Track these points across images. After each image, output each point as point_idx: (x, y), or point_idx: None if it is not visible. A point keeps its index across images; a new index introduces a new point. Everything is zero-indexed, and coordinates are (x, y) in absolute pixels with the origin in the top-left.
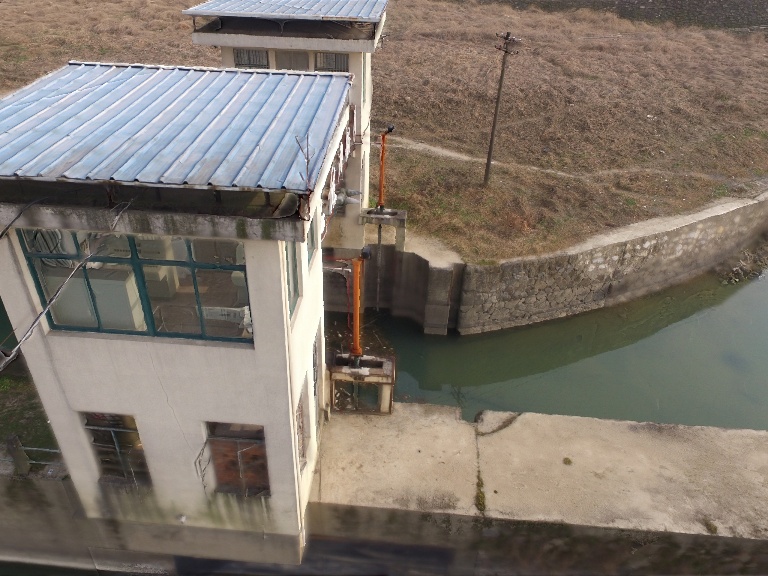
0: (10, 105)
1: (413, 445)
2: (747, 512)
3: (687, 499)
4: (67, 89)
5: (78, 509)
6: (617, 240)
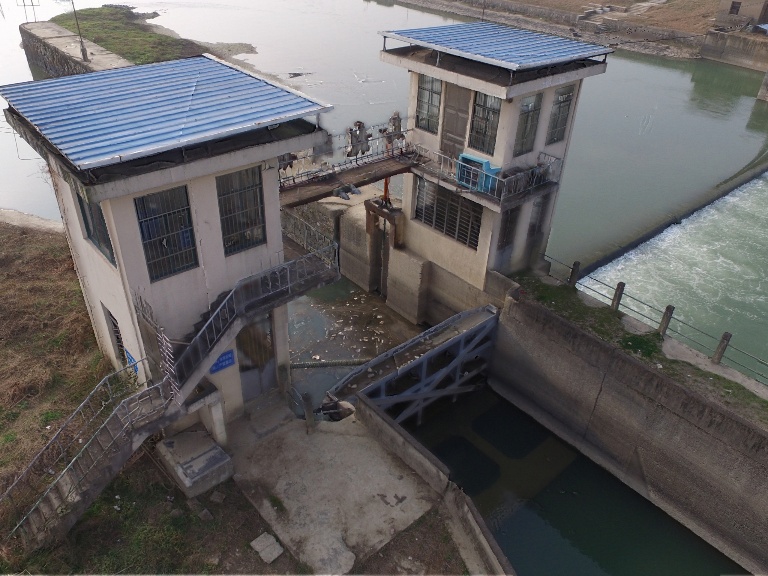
0: (563, 54)
1: None
2: None
3: None
4: None
5: (548, 263)
6: (60, 223)
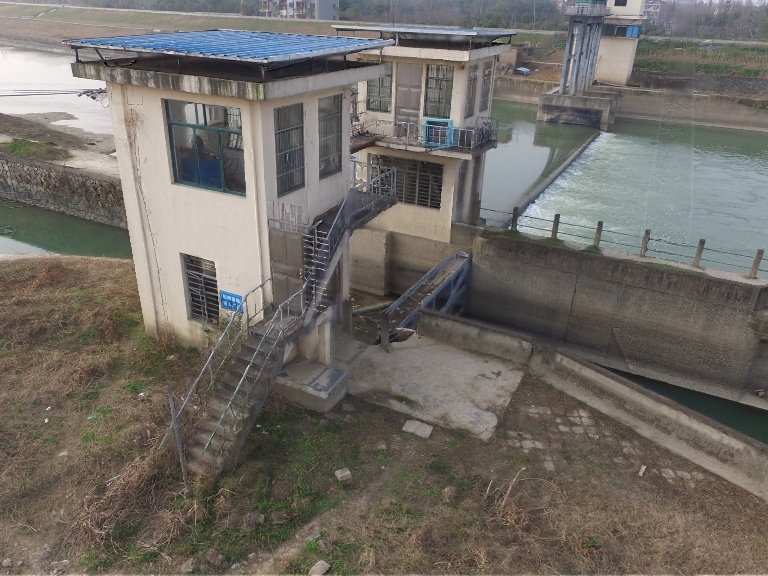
0: None
1: None
2: None
3: None
4: None
5: (484, 220)
6: None
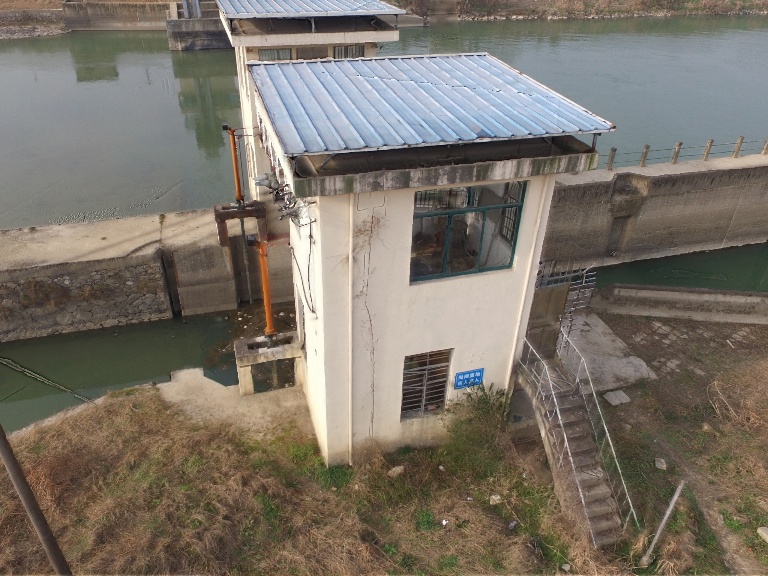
0: None
1: (202, 229)
2: (3, 237)
3: (37, 236)
4: (369, 5)
5: None
6: None
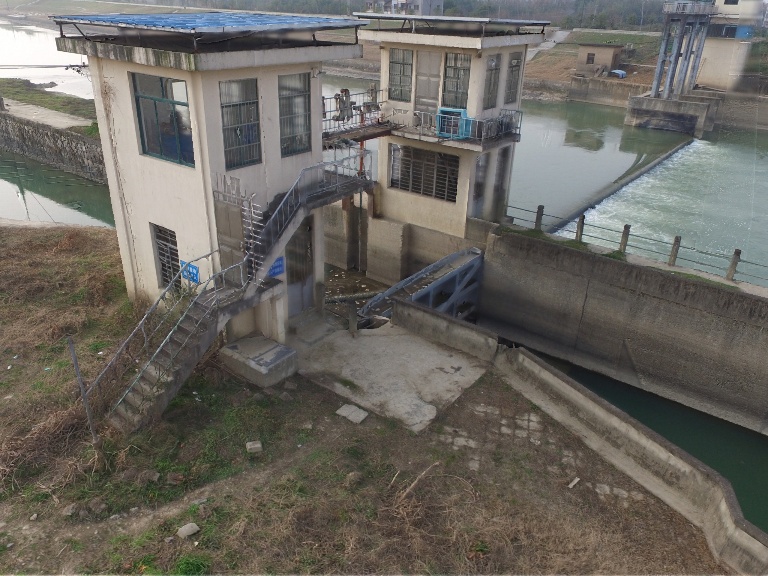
0: None
1: None
2: None
3: None
4: None
5: (511, 218)
6: (34, 222)
